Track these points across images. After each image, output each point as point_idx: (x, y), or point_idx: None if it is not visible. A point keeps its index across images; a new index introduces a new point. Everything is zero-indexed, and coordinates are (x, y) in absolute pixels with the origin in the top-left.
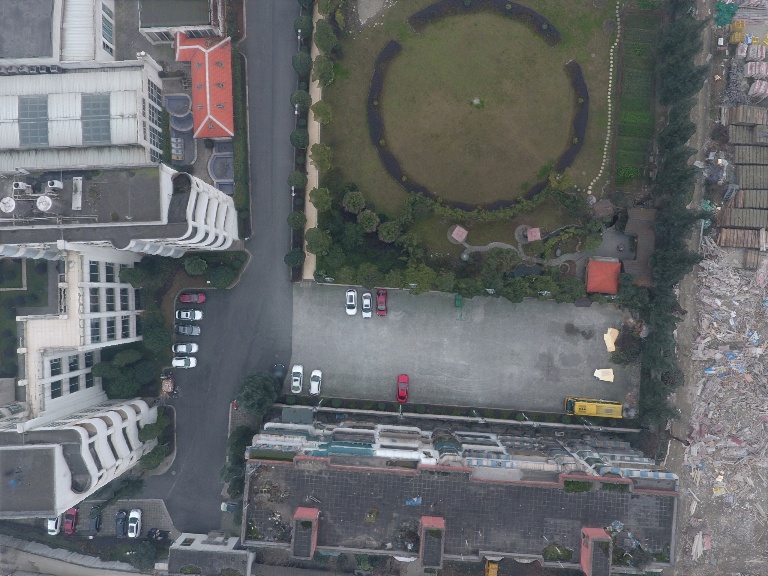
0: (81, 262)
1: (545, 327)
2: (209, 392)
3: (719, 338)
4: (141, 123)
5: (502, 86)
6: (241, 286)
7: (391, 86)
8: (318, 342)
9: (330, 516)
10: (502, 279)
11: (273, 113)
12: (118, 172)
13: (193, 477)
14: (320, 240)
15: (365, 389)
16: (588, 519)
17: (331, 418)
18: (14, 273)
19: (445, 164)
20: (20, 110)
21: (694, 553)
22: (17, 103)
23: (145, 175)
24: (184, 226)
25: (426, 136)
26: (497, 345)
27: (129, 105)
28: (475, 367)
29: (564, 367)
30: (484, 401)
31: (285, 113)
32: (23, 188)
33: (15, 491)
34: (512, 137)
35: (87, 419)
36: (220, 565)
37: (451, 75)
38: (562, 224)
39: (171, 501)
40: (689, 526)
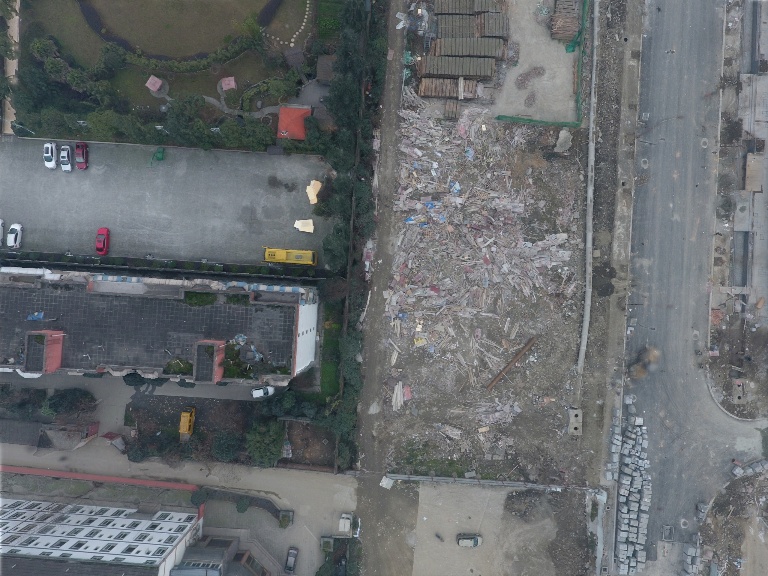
0: None
1: (248, 180)
2: None
3: (419, 188)
4: None
5: None
6: None
7: None
8: (20, 197)
9: None
10: (186, 123)
11: None
12: None
13: None
14: None
15: (67, 243)
16: (211, 332)
17: None
18: None
19: (148, 18)
20: None
21: (394, 403)
22: None
23: None
24: None
25: None
26: (199, 198)
27: None
28: (177, 220)
29: (267, 220)
30: (186, 254)
31: None
32: None
33: None
34: None
35: None
36: None
37: None
38: (265, 77)
39: None
40: (390, 377)
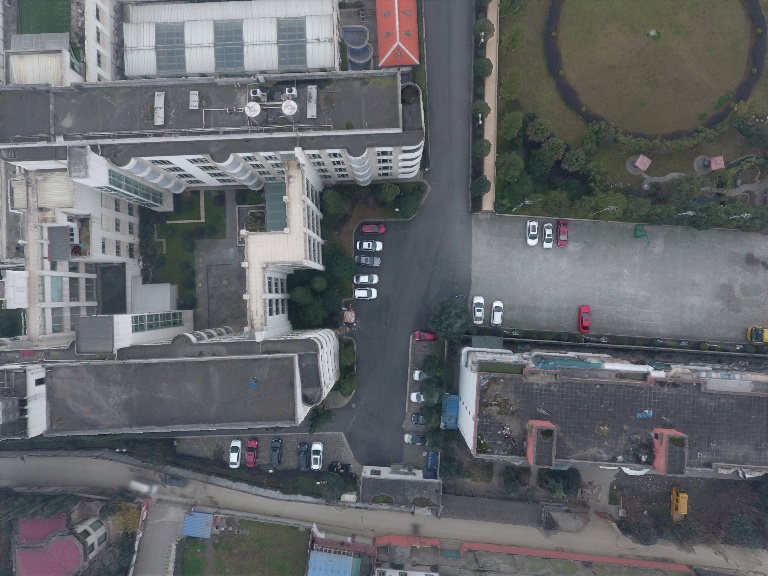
0: (302, 177)
1: (725, 257)
2: (389, 324)
3: None
4: (336, 47)
5: (678, 17)
6: (420, 217)
7: (568, 18)
8: (498, 273)
9: (560, 429)
10: None
11: (450, 45)
12: (352, 81)
13: (374, 410)
14: (521, 162)
15: (545, 320)
16: None
17: (513, 349)
18: (192, 205)
19: (623, 95)
20: (215, 35)
21: None
22: (212, 28)
23: (379, 84)
24: (419, 134)
25: (603, 67)
26: (677, 275)
27: (325, 29)
28: (656, 298)
29: (745, 297)
30: (665, 332)
31: (462, 45)
32: (260, 96)
33: (251, 402)
34: (689, 68)
35: (307, 335)
36: (412, 494)
37: (627, 7)
38: (741, 154)
39: (352, 434)
40: None
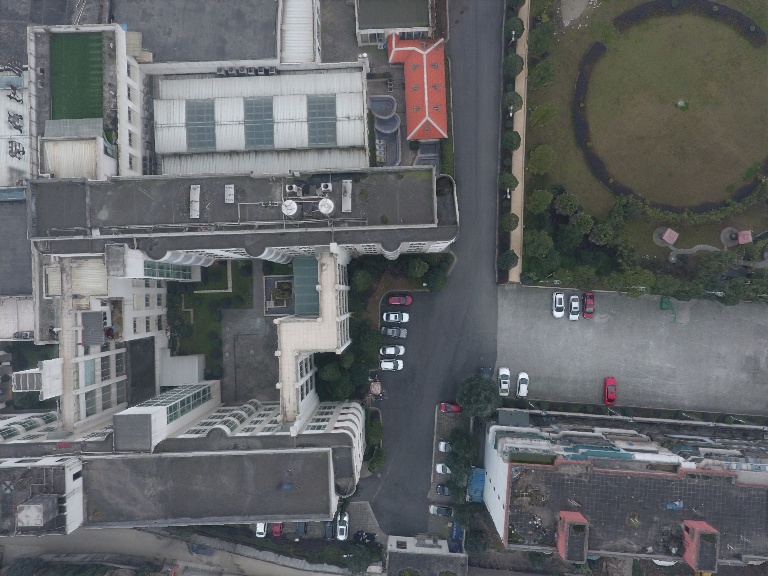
0: (334, 265)
1: (751, 330)
2: (415, 394)
3: None
4: (366, 125)
5: (707, 88)
6: (446, 288)
7: (595, 88)
8: (523, 345)
9: (590, 520)
10: None
11: (477, 115)
12: (386, 175)
13: (399, 480)
14: (551, 243)
15: (571, 392)
16: None
17: (538, 421)
18: (220, 275)
19: (650, 166)
20: (245, 112)
21: None
22: (242, 105)
23: (413, 178)
24: (454, 229)
25: (631, 138)
26: (703, 348)
27: (355, 107)
28: (681, 370)
29: None
30: (690, 404)
31: (489, 115)
32: (295, 191)
33: (285, 494)
34: (717, 139)
35: (339, 422)
36: (438, 568)
37: (655, 77)
38: (767, 227)
39: (377, 504)
40: None
